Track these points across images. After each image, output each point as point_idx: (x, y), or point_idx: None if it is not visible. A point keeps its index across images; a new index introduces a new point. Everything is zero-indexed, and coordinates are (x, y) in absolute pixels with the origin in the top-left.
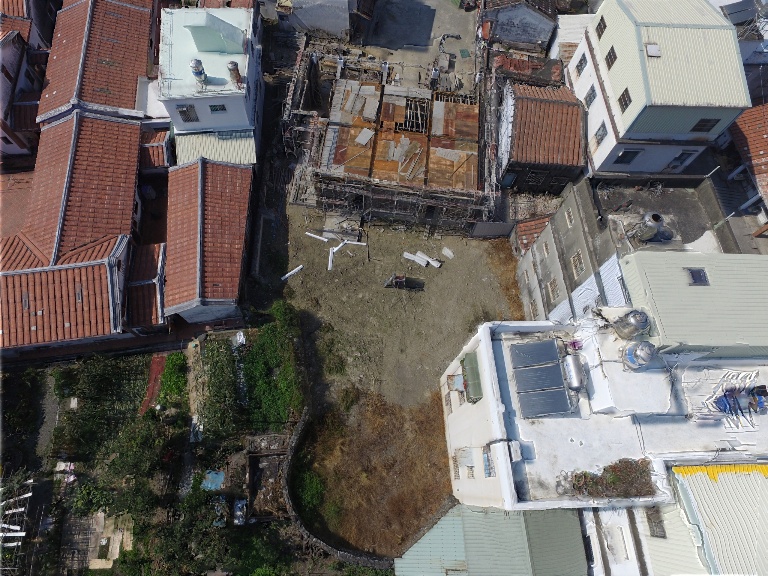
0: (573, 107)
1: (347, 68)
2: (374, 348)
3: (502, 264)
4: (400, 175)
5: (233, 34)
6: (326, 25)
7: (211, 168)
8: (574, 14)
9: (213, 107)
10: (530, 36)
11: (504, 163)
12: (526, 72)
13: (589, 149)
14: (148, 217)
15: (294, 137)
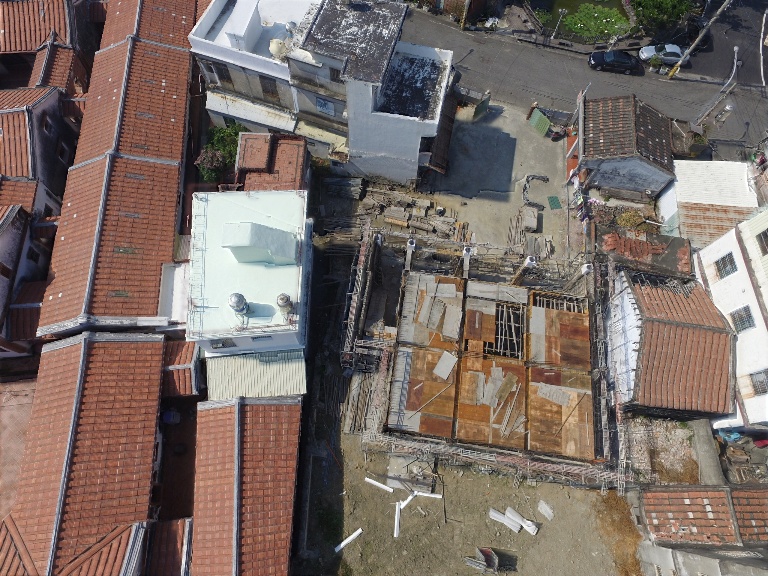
0: (720, 335)
1: (418, 250)
2: None
3: (617, 531)
4: (493, 428)
5: (283, 244)
6: (388, 173)
7: (251, 411)
8: (694, 160)
9: (255, 337)
10: (637, 185)
11: (621, 394)
12: (645, 258)
13: (738, 388)
14: (170, 452)
15: (355, 361)
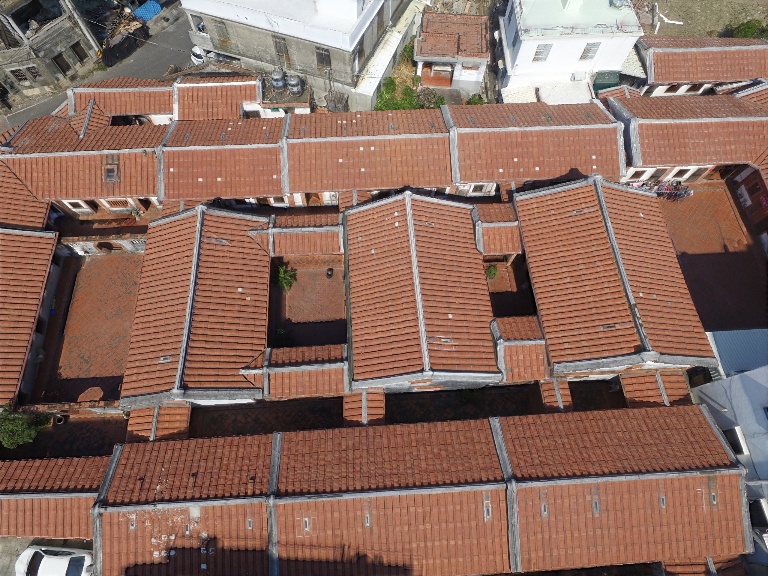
0: None
1: None
2: (736, 6)
3: None
4: None
5: None
6: None
7: None
8: None
9: None
10: None
11: None
12: None
13: None
14: None
15: None
